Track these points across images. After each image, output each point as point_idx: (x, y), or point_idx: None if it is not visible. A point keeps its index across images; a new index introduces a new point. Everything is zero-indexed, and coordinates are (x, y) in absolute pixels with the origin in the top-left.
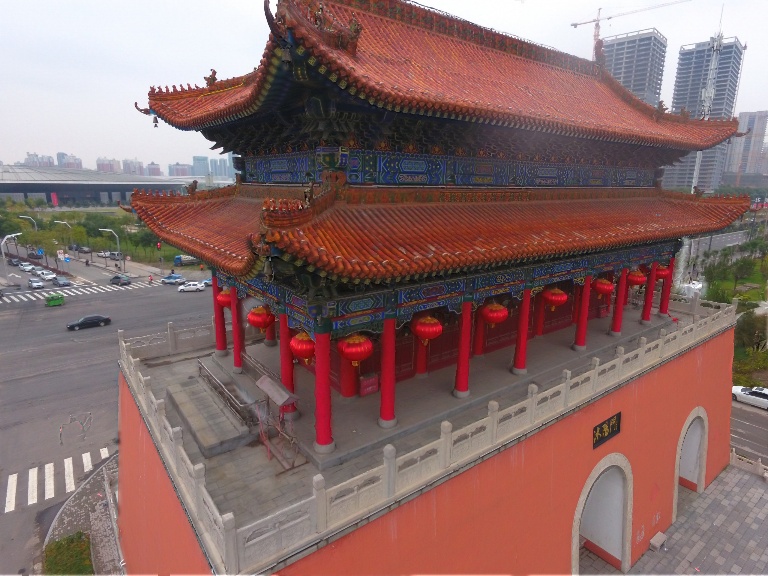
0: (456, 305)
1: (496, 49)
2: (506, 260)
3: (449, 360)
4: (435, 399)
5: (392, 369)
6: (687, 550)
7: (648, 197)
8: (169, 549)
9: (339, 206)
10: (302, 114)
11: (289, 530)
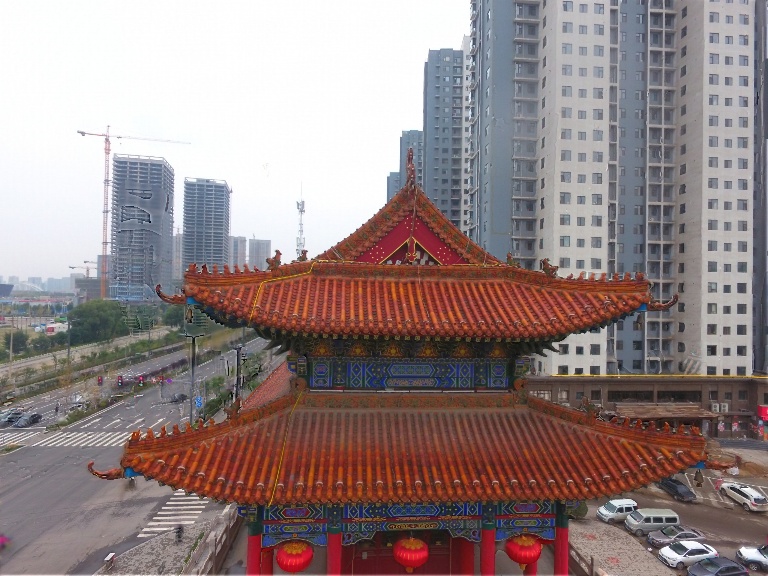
0: None
1: None
2: None
3: None
4: (497, 554)
5: None
6: None
7: None
8: None
9: None
10: None
11: None
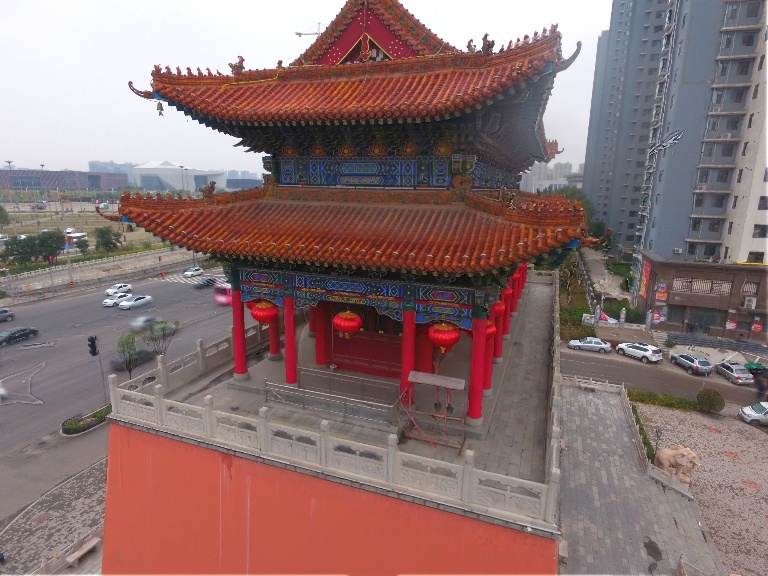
0: None
1: None
2: None
3: None
4: None
5: None
6: (576, 445)
7: None
8: (367, 569)
9: None
10: (458, 125)
11: None
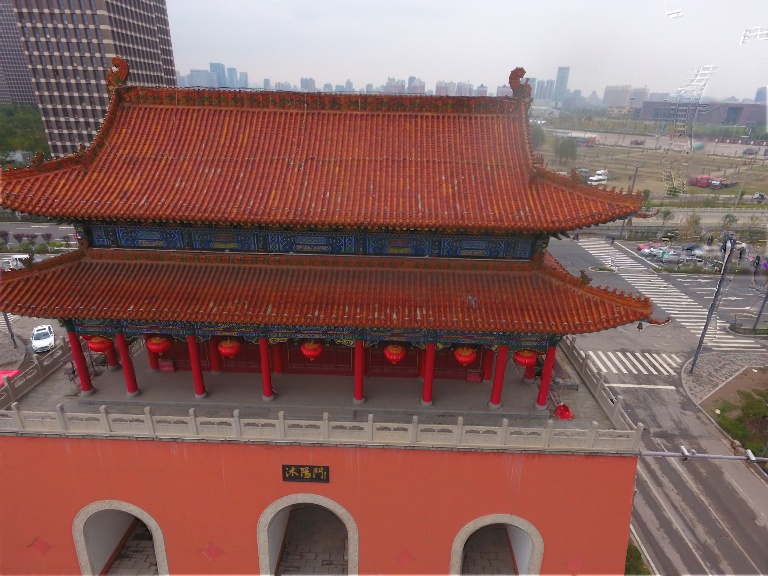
0: (180, 335)
1: (326, 110)
2: (148, 319)
3: (245, 368)
4: (186, 391)
5: (124, 363)
6: None
7: (510, 271)
8: None
9: (86, 260)
10: None
11: (4, 421)
